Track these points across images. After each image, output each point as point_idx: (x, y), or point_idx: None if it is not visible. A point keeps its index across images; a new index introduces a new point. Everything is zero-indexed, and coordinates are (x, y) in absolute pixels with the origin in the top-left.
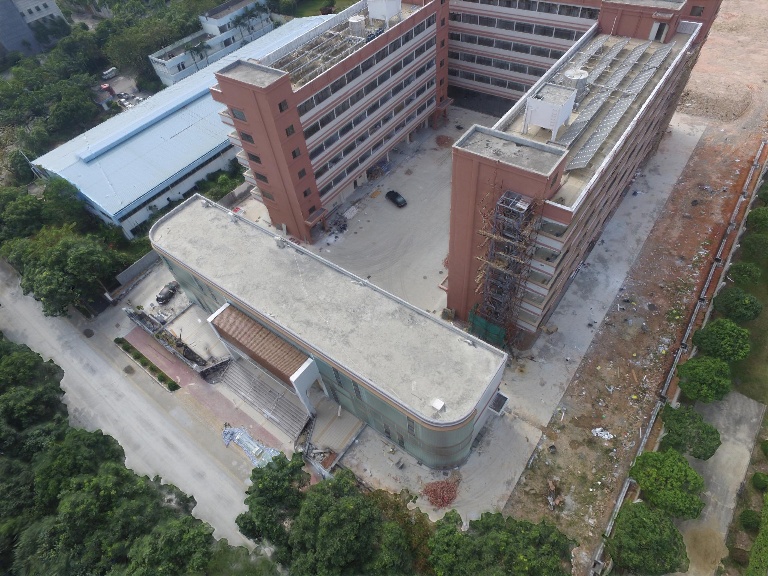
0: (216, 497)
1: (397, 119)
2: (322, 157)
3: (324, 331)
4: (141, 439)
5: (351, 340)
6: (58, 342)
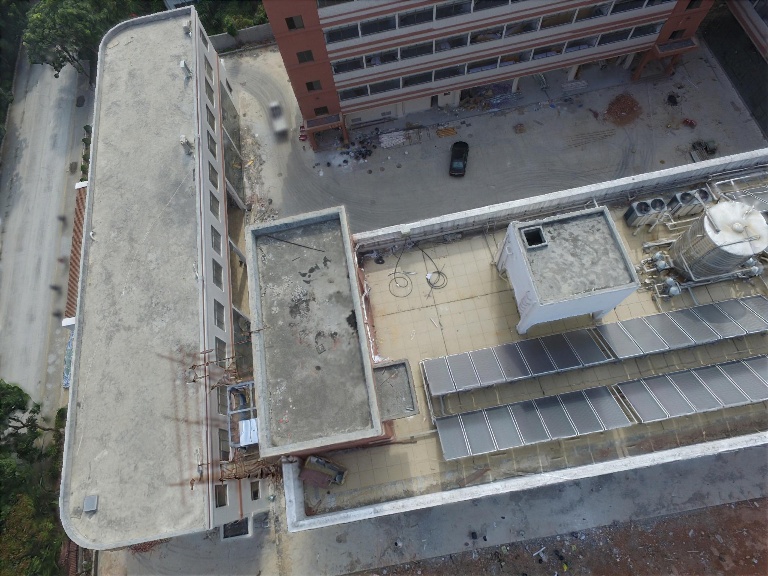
0: (23, 348)
1: (545, 36)
2: (353, 45)
3: (109, 302)
4: (27, 244)
5: (116, 339)
6: (56, 93)
